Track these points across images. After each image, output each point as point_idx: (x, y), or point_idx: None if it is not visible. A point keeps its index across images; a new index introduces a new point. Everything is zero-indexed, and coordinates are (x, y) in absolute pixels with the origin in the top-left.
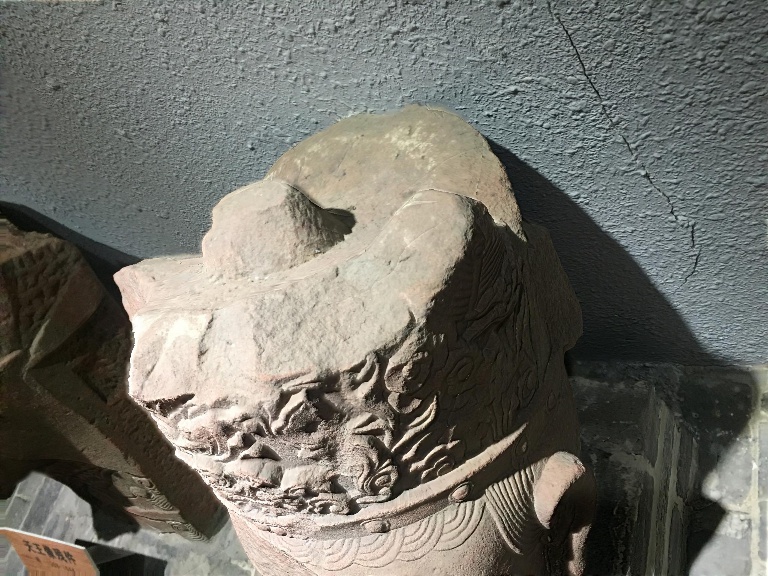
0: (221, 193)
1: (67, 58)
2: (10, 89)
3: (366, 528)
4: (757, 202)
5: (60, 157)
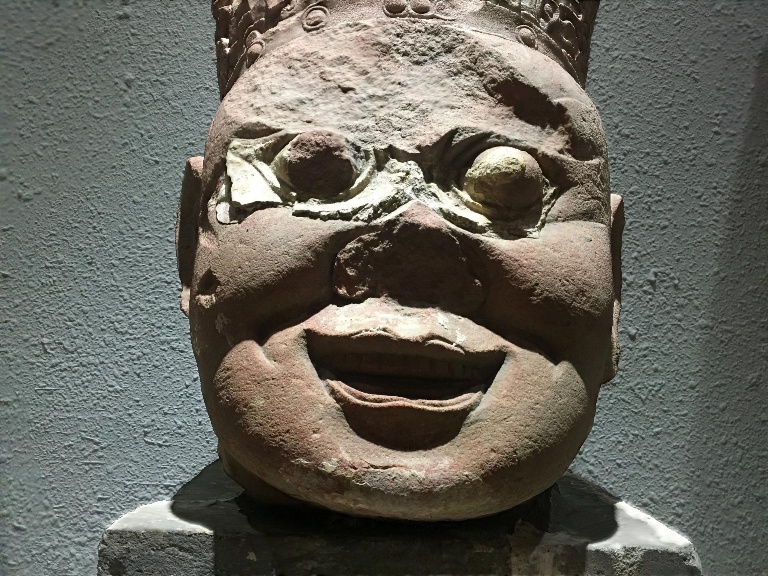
0: (154, 180)
1: (175, 1)
2: (68, 1)
3: (520, 33)
4: (626, 304)
5: (2, 80)
